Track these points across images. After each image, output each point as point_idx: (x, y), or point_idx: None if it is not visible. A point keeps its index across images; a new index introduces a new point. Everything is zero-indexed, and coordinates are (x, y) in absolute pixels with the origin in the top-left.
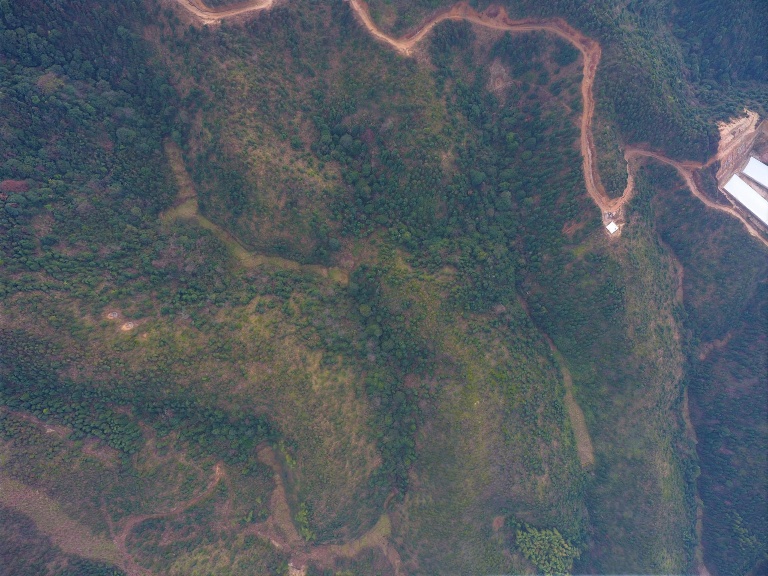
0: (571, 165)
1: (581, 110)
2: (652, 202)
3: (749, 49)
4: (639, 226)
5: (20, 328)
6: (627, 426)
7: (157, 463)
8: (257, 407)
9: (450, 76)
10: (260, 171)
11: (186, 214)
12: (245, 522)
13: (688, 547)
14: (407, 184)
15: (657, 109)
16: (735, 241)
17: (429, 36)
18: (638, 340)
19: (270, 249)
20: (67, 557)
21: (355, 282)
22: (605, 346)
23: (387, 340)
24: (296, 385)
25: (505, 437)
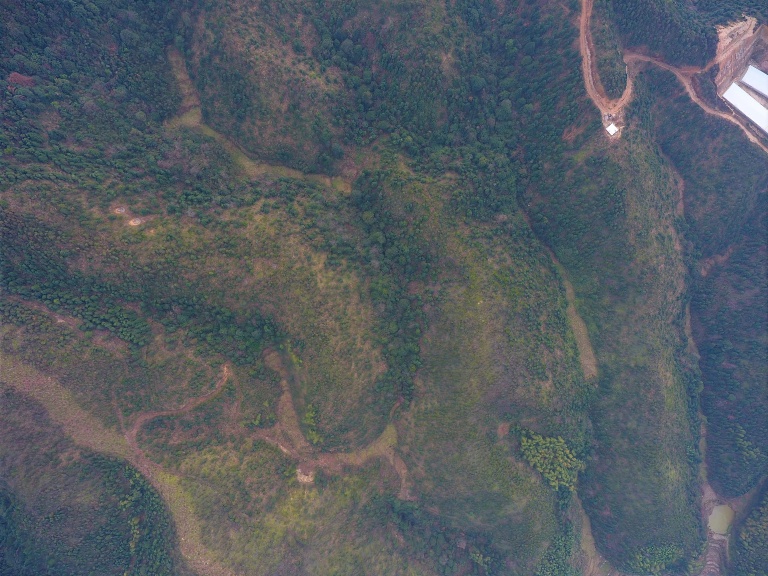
0: (570, 66)
1: (579, 9)
2: (652, 111)
3: None
4: (639, 132)
5: (30, 212)
6: (630, 334)
7: (166, 356)
8: (263, 306)
9: None
10: (263, 71)
11: (190, 123)
12: (253, 427)
13: (692, 461)
14: (408, 87)
15: (655, 7)
16: (735, 148)
17: None
18: (639, 246)
19: (273, 157)
20: (79, 449)
21: (358, 189)
22: (607, 254)
23: (390, 247)
24: (301, 281)
25: (509, 338)
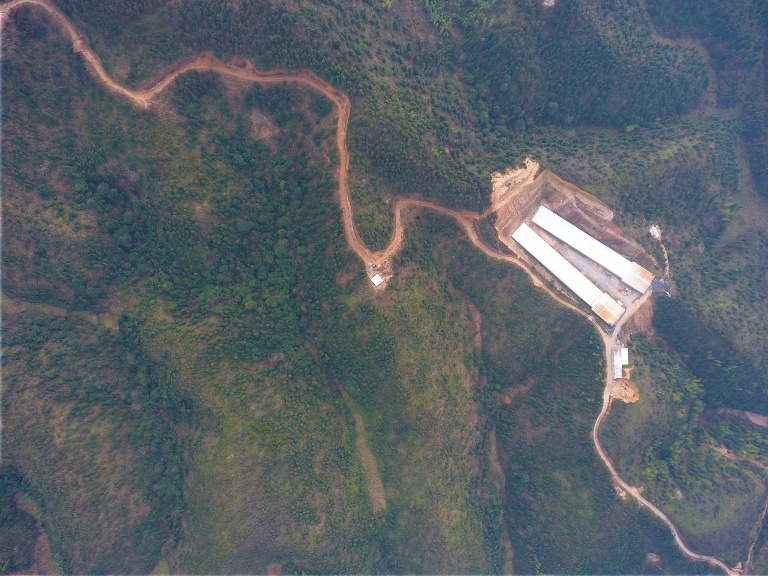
0: (332, 217)
1: (337, 163)
2: (437, 250)
3: (542, 96)
4: (416, 276)
5: None
6: (410, 475)
7: None
8: None
9: (205, 126)
10: None
11: None
12: None
13: None
14: (163, 234)
15: (416, 162)
16: (520, 291)
17: (170, 88)
18: (414, 391)
19: None
20: None
21: (120, 330)
22: (385, 395)
23: (154, 389)
24: (32, 440)
25: (266, 489)
